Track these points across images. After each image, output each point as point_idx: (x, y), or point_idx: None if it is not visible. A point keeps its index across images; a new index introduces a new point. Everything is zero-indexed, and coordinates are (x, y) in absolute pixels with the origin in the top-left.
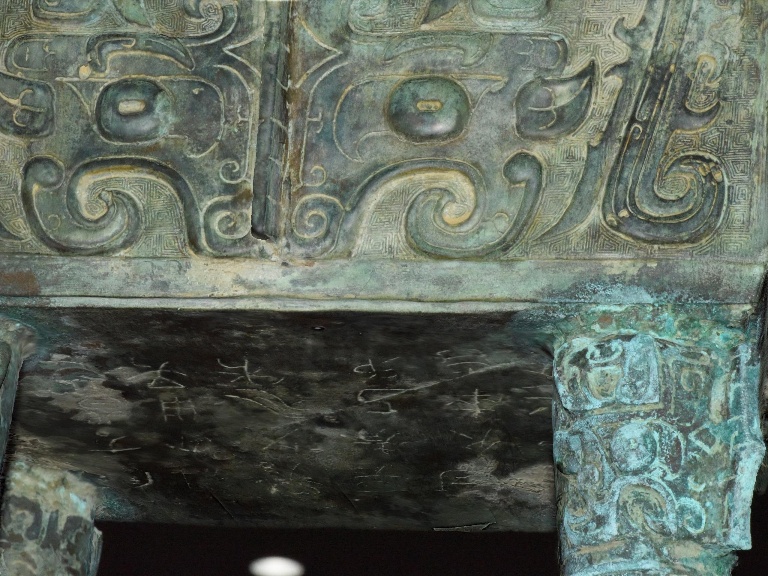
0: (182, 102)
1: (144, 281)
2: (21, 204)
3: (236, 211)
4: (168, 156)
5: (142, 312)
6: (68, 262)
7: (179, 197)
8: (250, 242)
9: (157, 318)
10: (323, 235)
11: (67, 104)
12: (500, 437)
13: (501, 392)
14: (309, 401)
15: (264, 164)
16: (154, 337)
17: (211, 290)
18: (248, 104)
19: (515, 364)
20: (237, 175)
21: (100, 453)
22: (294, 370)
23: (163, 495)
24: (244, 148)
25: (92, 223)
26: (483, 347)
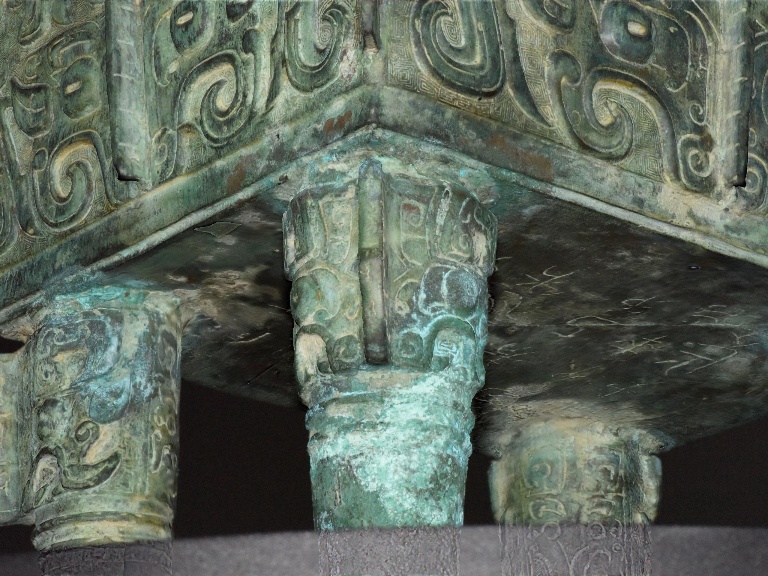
0: (662, 36)
1: (628, 194)
2: (549, 91)
3: (703, 151)
4: (655, 83)
5: (608, 220)
6: (578, 158)
7: (661, 124)
8: (712, 183)
9: (605, 227)
10: (759, 193)
11: (582, 7)
12: (593, 373)
13: (674, 342)
14: (533, 313)
15: (747, 119)
16: (556, 238)
17: (672, 217)
18: (707, 55)
19: (736, 326)
20: (702, 118)
21: (272, 309)
22: (585, 289)
23: (233, 353)
24: (705, 94)
25: (605, 128)
26: (755, 310)
